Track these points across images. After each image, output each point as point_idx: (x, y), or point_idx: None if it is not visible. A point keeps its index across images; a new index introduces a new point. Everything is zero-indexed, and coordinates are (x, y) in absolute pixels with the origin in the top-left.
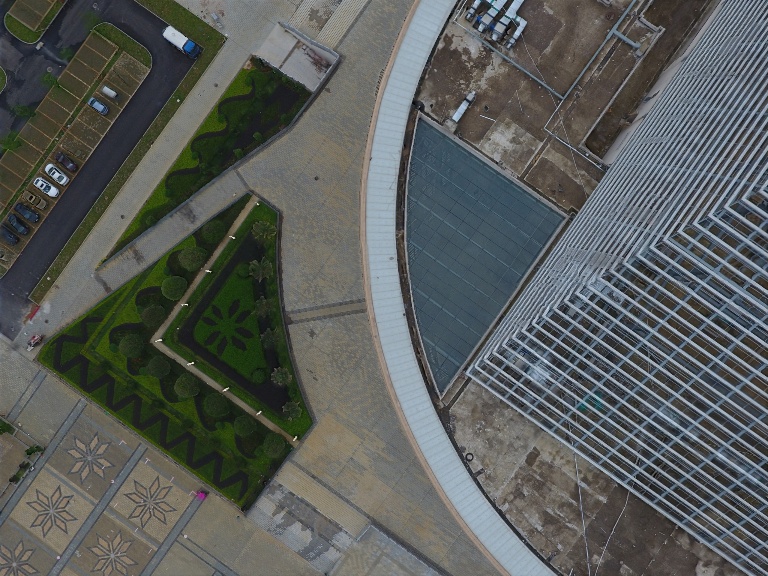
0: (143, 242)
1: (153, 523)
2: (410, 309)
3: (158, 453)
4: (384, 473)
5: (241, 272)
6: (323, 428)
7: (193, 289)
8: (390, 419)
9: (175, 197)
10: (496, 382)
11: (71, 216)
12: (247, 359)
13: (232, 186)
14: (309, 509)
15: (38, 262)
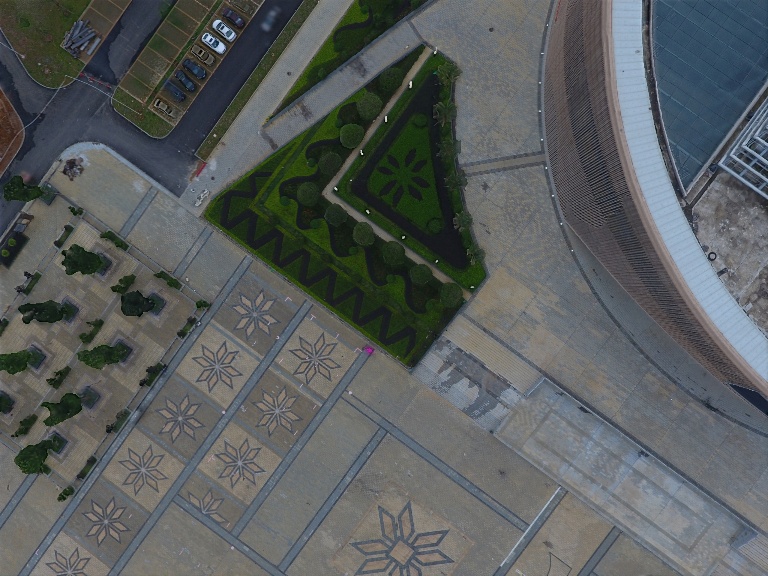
0: (311, 97)
1: (318, 379)
2: (654, 105)
3: (323, 310)
4: (557, 327)
5: (418, 121)
6: (495, 282)
7: (365, 141)
8: (564, 273)
9: (345, 51)
10: (753, 171)
11: (237, 73)
12: (423, 208)
13: (405, 38)
14: (477, 365)
15: (204, 119)
